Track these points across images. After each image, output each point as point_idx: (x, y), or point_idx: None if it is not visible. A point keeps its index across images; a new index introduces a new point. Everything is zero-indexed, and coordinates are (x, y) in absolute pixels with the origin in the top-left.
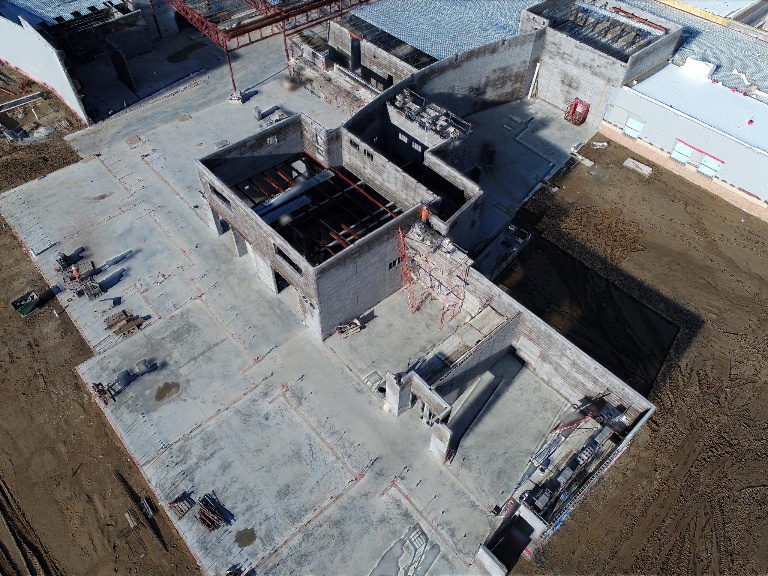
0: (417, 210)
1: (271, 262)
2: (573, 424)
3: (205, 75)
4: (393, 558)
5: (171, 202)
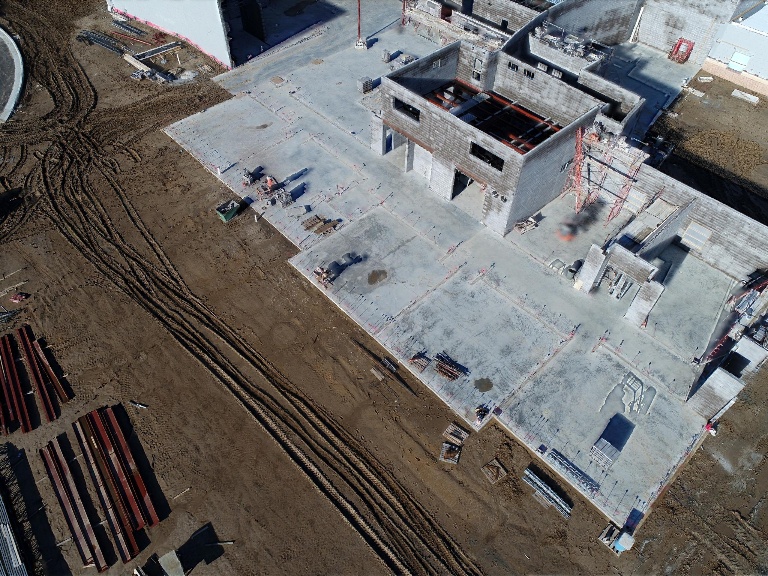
0: (594, 113)
1: (457, 165)
2: (758, 286)
3: (324, 26)
4: (617, 398)
5: (329, 130)
